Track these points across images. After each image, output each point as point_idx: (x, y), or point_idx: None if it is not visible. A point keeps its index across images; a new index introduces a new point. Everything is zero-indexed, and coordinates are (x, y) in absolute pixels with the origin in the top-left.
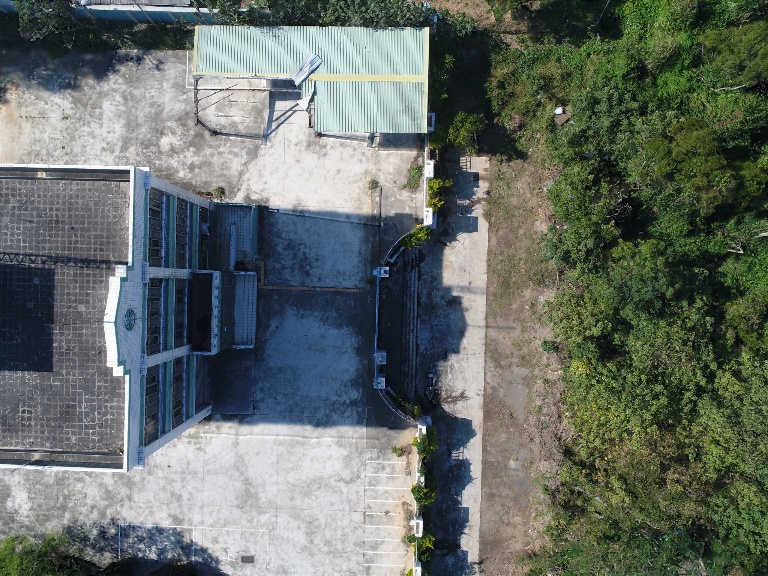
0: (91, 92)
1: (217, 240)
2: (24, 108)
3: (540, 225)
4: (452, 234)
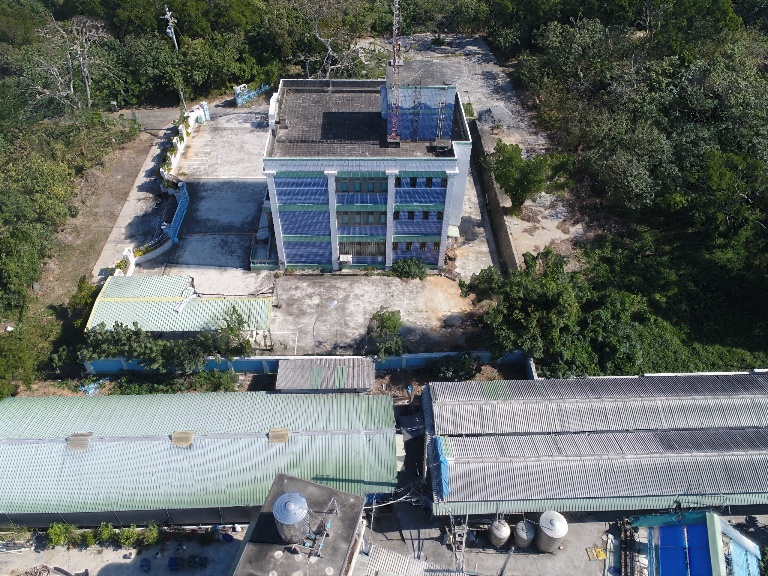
0: None
1: None
2: (425, 317)
3: (55, 269)
4: None
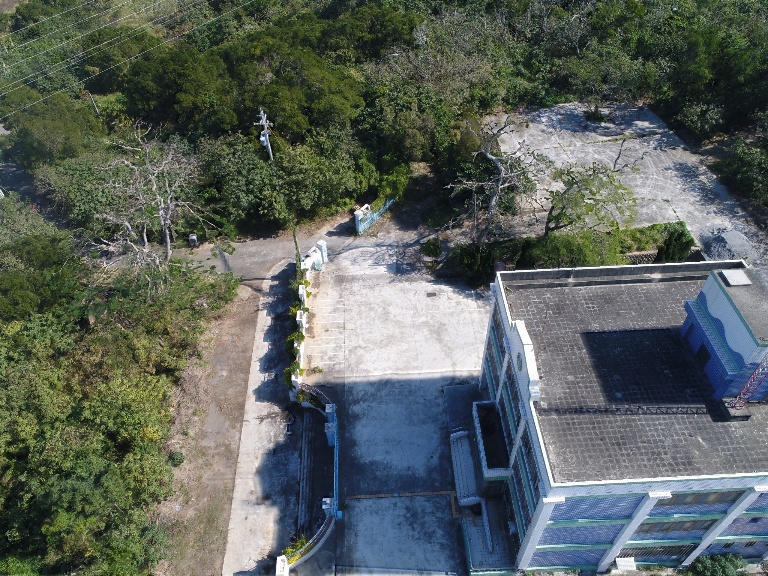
0: None
1: (505, 533)
2: None
3: None
4: (261, 568)
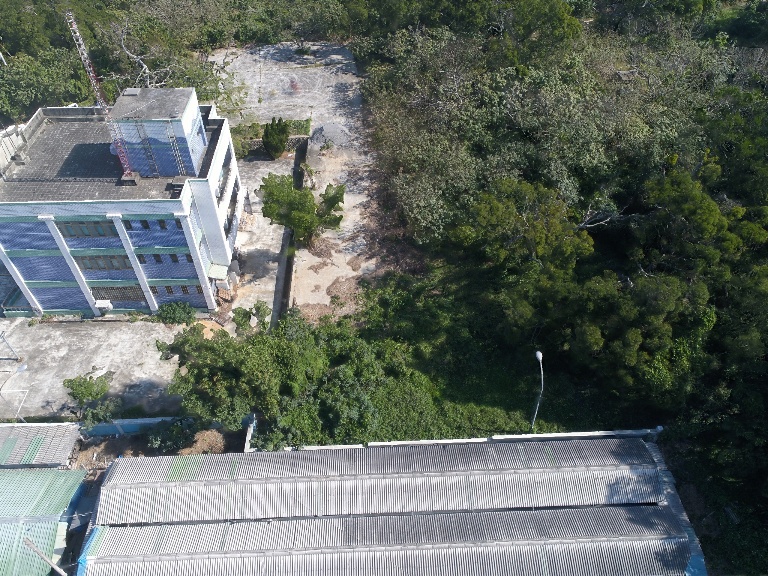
0: (113, 383)
1: None
2: None
3: None
4: None
